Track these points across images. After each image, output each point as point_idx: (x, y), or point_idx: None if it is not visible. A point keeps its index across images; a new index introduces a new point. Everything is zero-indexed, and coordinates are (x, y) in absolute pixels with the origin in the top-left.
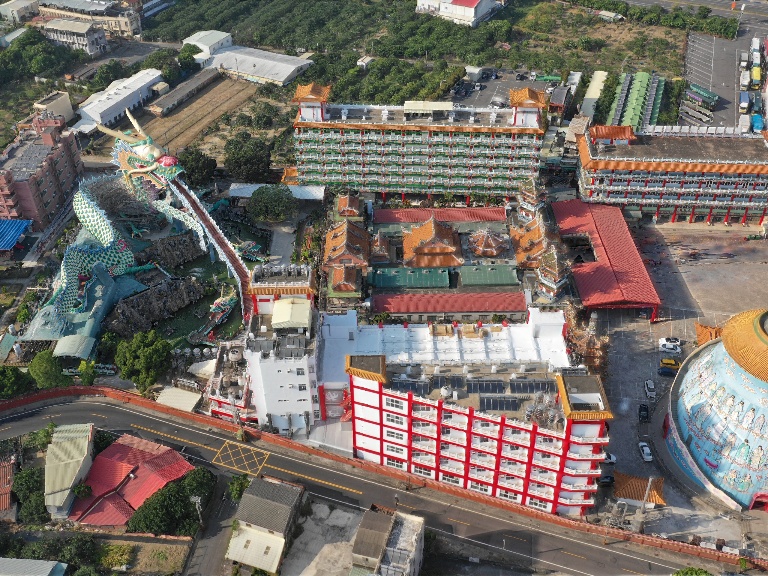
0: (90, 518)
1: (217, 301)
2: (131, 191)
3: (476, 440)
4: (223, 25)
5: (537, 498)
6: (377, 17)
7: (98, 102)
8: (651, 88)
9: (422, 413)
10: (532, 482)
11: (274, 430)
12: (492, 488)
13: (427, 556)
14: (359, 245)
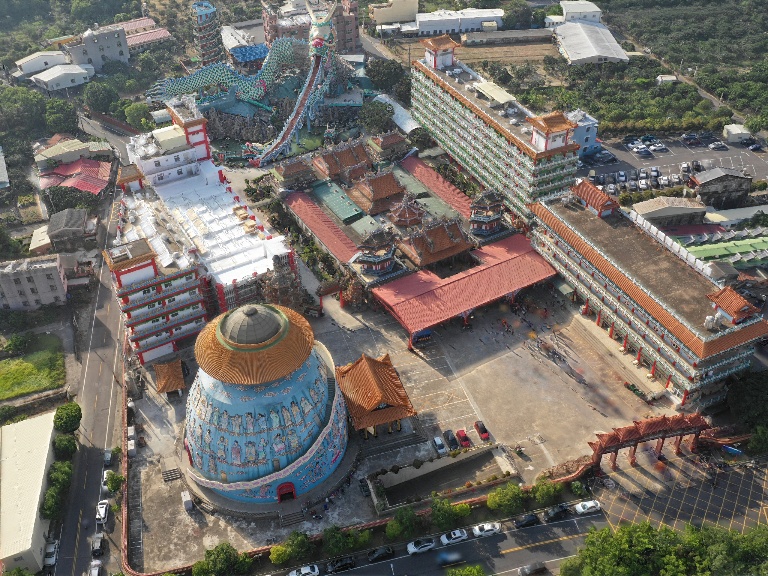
0: (44, 179)
1: (253, 143)
2: None
3: None
4: (629, 7)
5: None
6: None
7: (430, 14)
8: None
9: None
10: None
11: None
12: None
13: (71, 304)
14: None
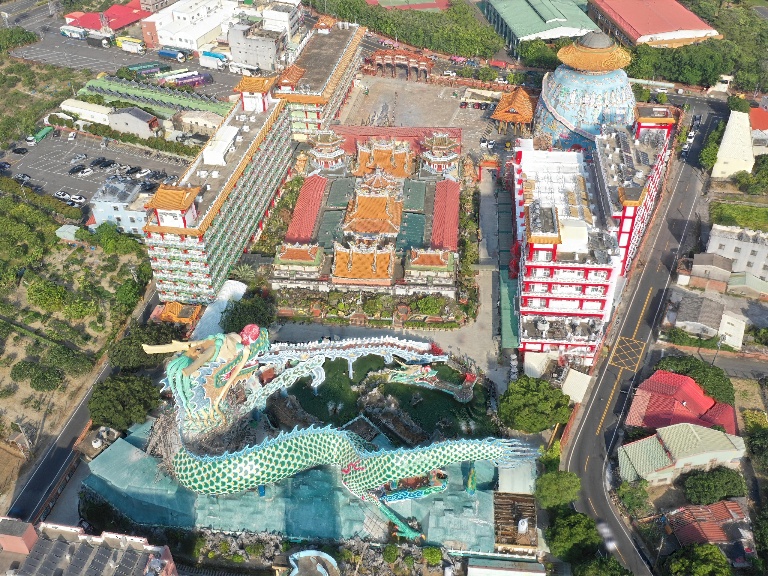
0: None
1: (420, 369)
2: (219, 426)
3: None
4: None
5: None
6: None
7: None
8: None
9: None
10: None
11: None
12: None
13: None
14: None
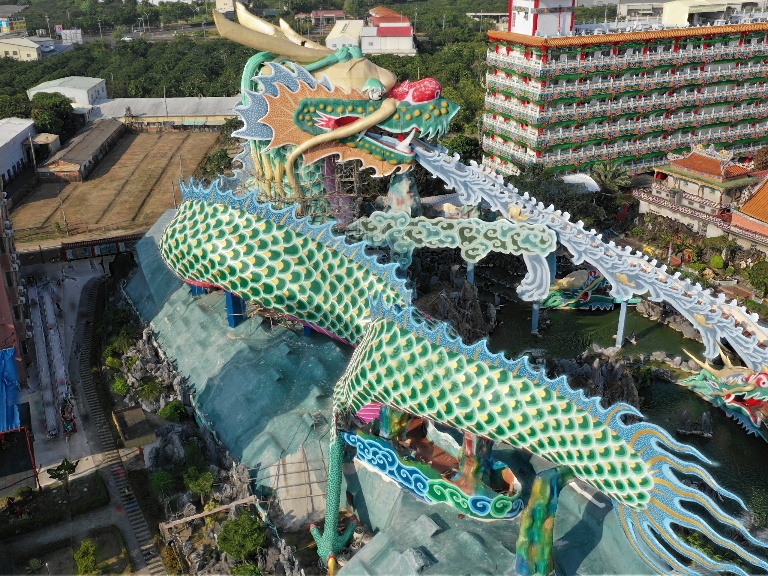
0: None
1: (746, 373)
2: None
3: None
4: None
5: None
6: None
7: None
8: None
9: None
10: None
11: None
12: None
13: None
14: None
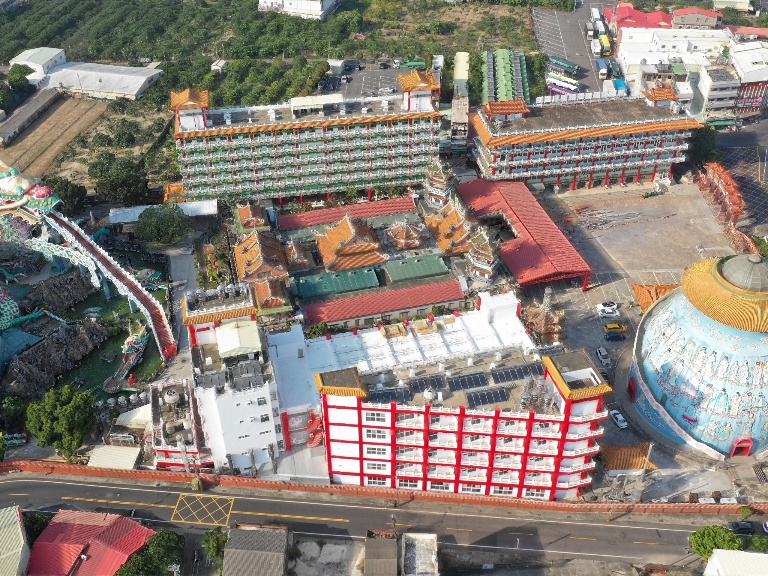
0: None
1: (128, 340)
2: None
3: (467, 440)
4: (50, 41)
5: (534, 488)
6: (219, 19)
7: None
8: (515, 64)
9: (407, 422)
10: (528, 472)
11: (234, 471)
12: (485, 487)
13: None
14: (275, 256)
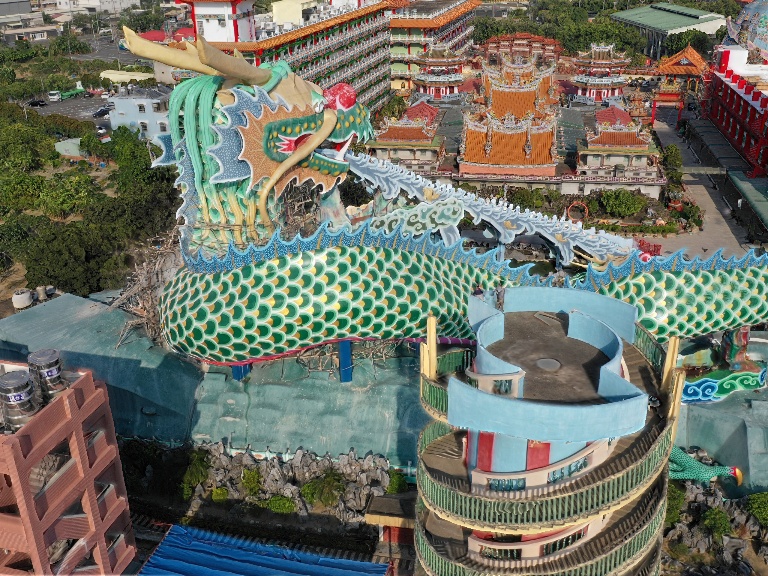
0: None
1: None
2: None
3: None
4: None
5: None
6: None
7: None
8: None
9: None
10: None
11: None
12: None
13: None
14: None
